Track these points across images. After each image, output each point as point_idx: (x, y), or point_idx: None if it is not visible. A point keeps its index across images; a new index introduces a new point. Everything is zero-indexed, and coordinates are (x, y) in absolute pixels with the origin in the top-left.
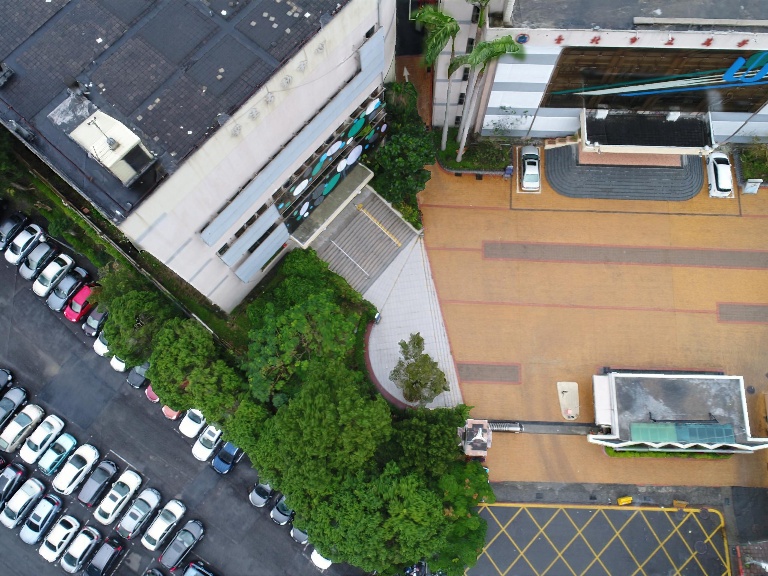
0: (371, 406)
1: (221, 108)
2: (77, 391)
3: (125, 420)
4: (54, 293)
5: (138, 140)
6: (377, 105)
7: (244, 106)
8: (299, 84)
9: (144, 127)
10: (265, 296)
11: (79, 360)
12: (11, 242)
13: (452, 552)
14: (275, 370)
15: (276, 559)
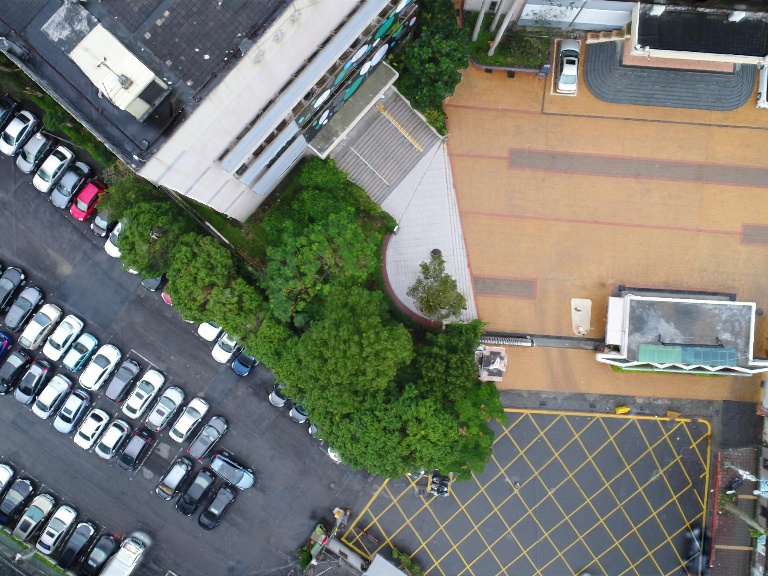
0: (394, 337)
1: (241, 27)
2: (92, 292)
3: (143, 321)
4: (57, 189)
5: (153, 77)
6: None
7: (269, 30)
8: None
9: (154, 48)
10: (282, 209)
11: (91, 260)
12: (3, 131)
13: (461, 459)
14: (295, 291)
15: (295, 451)
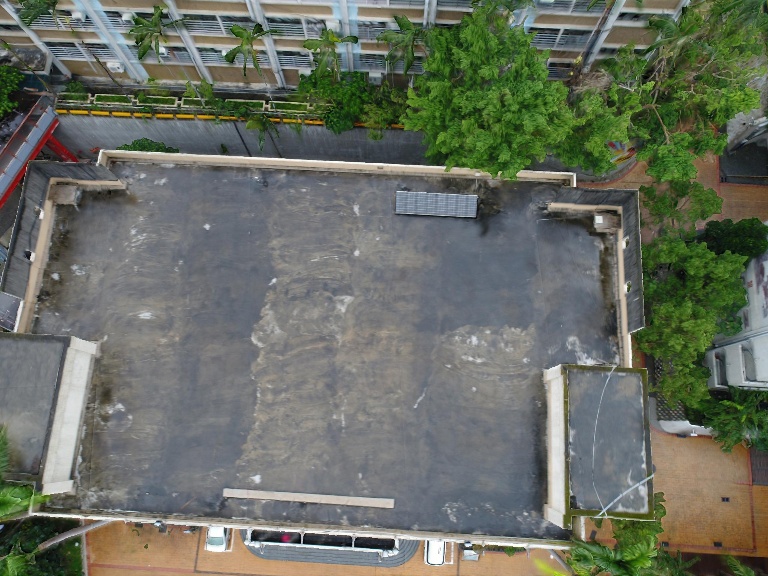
0: None
1: None
2: None
3: None
4: None
5: None
6: None
7: None
8: None
9: None
10: None
11: None
12: None
13: None
14: None
15: None
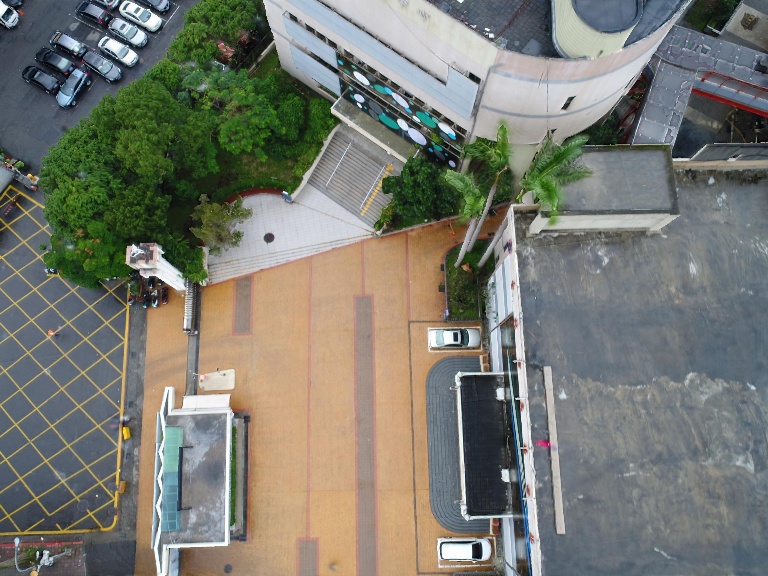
0: (156, 151)
1: None
2: None
3: None
4: None
5: None
6: (452, 136)
7: None
8: (395, 10)
9: None
10: None
11: None
12: None
13: None
14: None
15: None
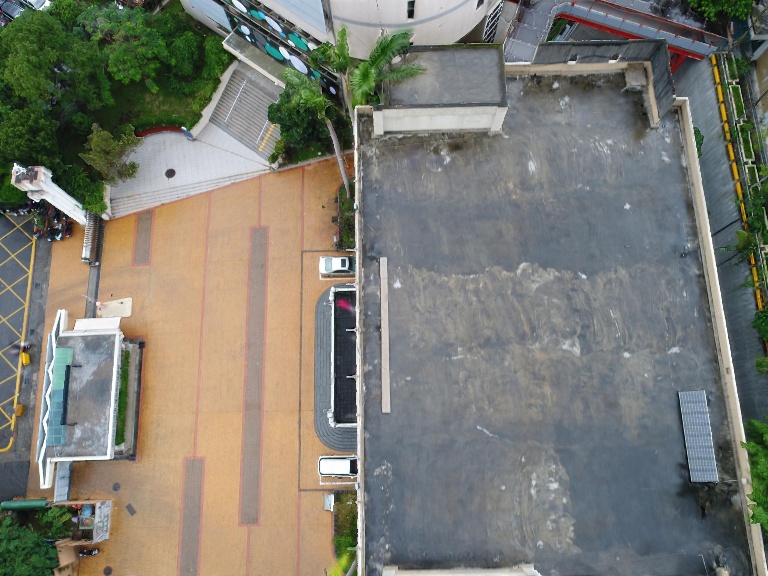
0: (38, 74)
1: None
2: None
3: None
4: None
5: None
6: None
7: None
8: None
9: None
10: None
11: None
12: None
13: None
14: None
15: None
